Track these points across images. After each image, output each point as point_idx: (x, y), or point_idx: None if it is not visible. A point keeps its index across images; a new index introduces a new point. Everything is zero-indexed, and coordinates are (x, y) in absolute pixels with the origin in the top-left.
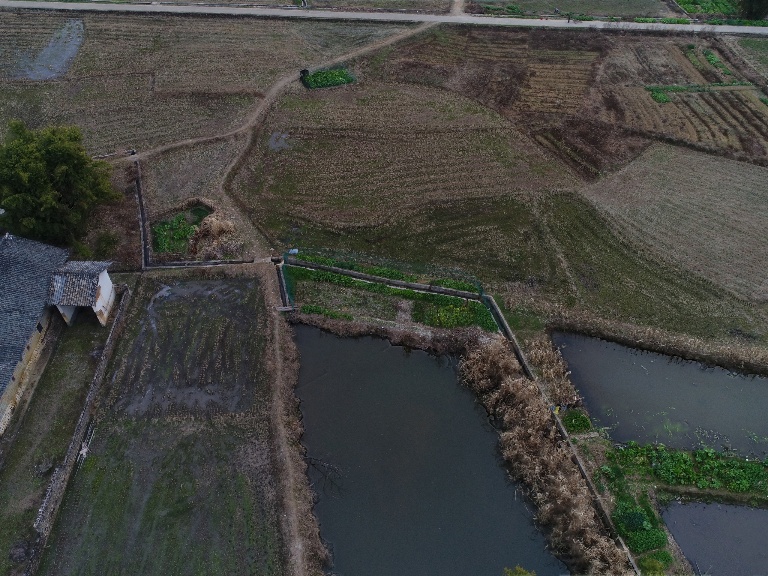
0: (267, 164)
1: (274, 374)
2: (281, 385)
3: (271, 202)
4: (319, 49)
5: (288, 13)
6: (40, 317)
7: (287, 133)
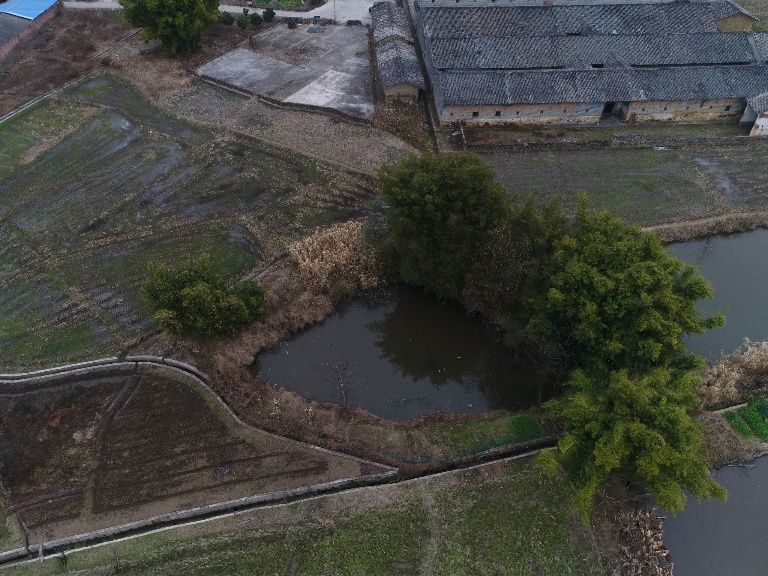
0: None
1: (767, 211)
2: (760, 214)
3: None
4: None
5: None
6: (735, 105)
7: None
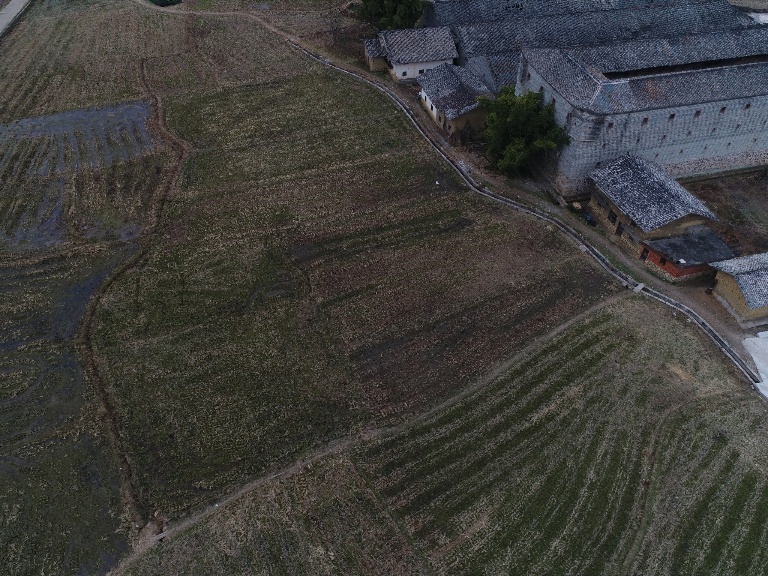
0: (290, 5)
1: None
2: None
3: (332, 0)
4: (100, 5)
5: (4, 20)
6: None
7: (248, 5)
